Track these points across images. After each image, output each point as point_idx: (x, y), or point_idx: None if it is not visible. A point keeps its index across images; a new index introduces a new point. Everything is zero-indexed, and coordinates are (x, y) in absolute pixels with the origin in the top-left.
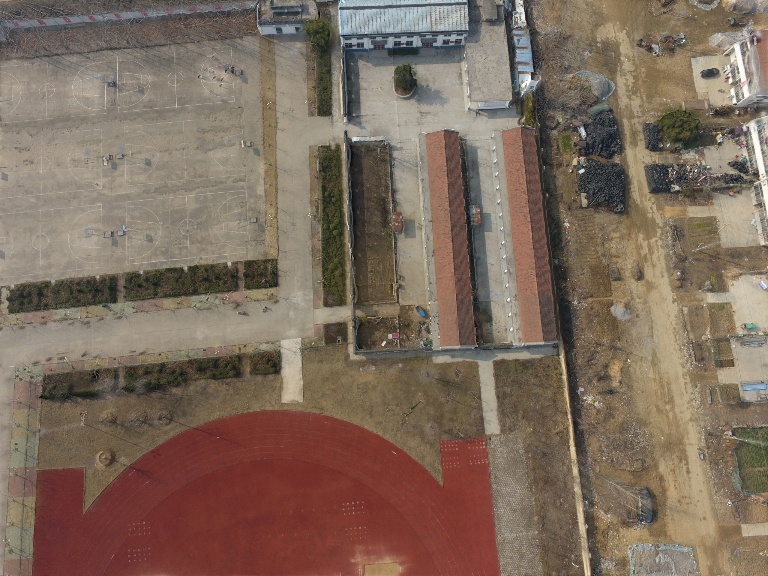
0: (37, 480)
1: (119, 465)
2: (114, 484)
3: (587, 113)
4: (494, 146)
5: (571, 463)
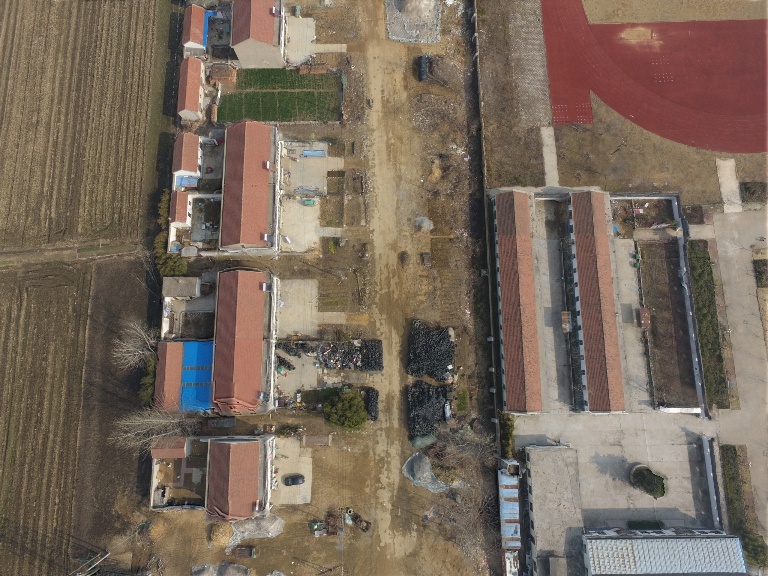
0: None
1: None
2: None
3: (438, 436)
4: None
5: None
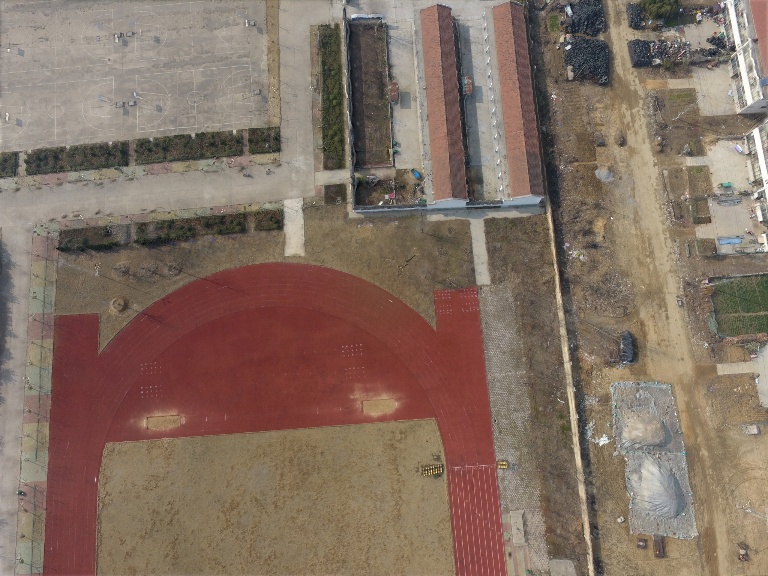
0: (54, 324)
1: (132, 311)
2: (127, 328)
3: None
4: (485, 23)
5: (557, 310)
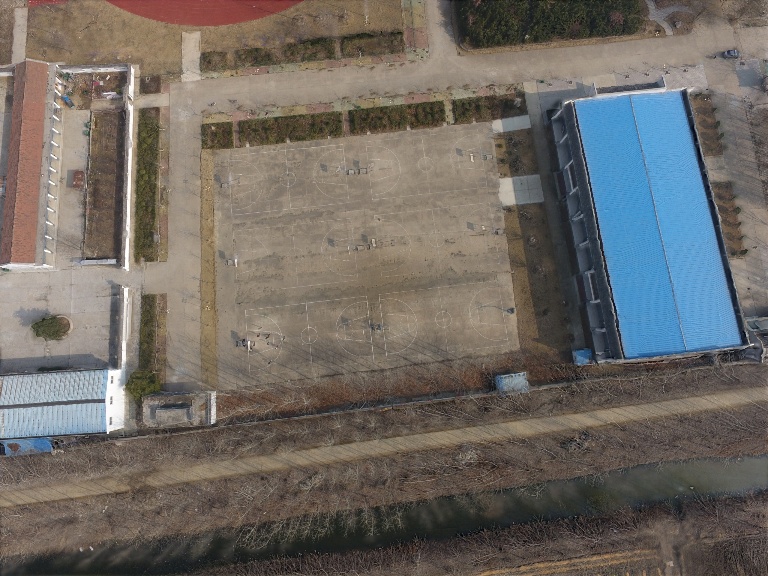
0: None
1: None
2: None
3: None
4: None
5: None
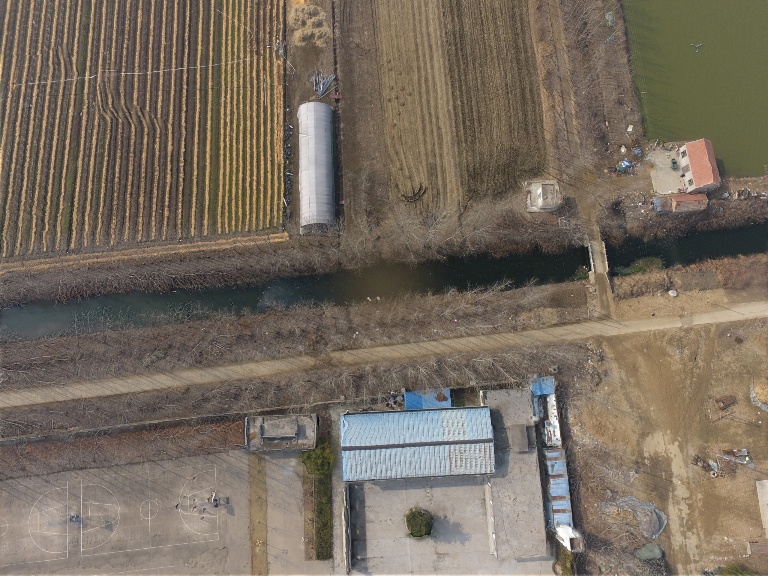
0: None
1: None
2: None
3: (634, 558)
4: None
5: None
